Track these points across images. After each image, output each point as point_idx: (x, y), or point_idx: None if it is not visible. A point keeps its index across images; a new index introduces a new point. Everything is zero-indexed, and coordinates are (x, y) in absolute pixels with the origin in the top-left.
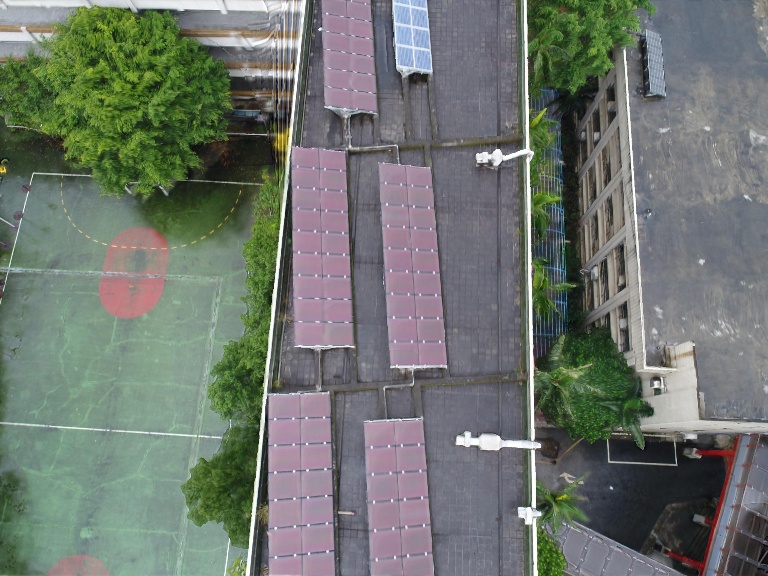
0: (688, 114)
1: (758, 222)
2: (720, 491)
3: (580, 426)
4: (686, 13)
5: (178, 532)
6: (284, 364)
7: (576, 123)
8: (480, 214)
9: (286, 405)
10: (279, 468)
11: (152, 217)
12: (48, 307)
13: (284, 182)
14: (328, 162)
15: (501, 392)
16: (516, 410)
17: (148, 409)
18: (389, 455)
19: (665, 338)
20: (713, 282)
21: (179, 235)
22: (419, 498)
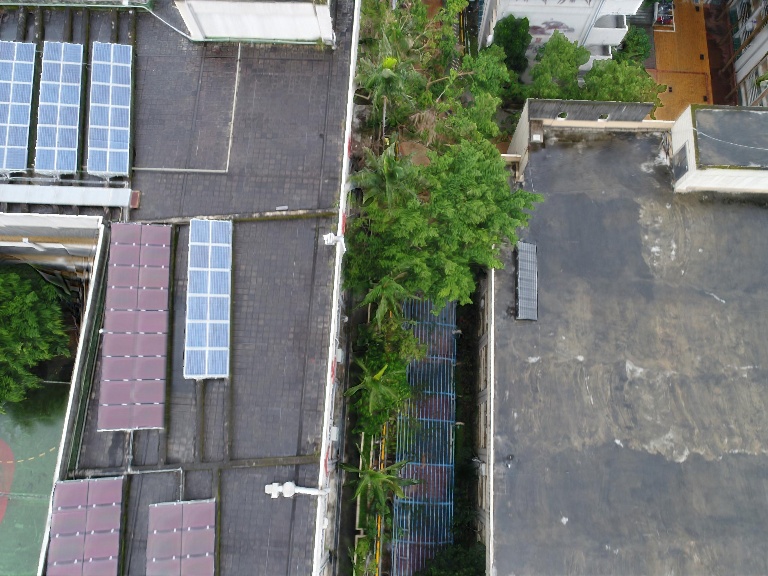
0: (561, 340)
1: (629, 473)
2: None
3: None
4: (566, 218)
5: None
6: None
7: (479, 284)
8: (268, 555)
9: None
10: None
11: None
12: None
13: None
14: (99, 496)
15: None
16: None
17: None
18: None
19: None
20: (575, 545)
21: (27, 446)
22: None
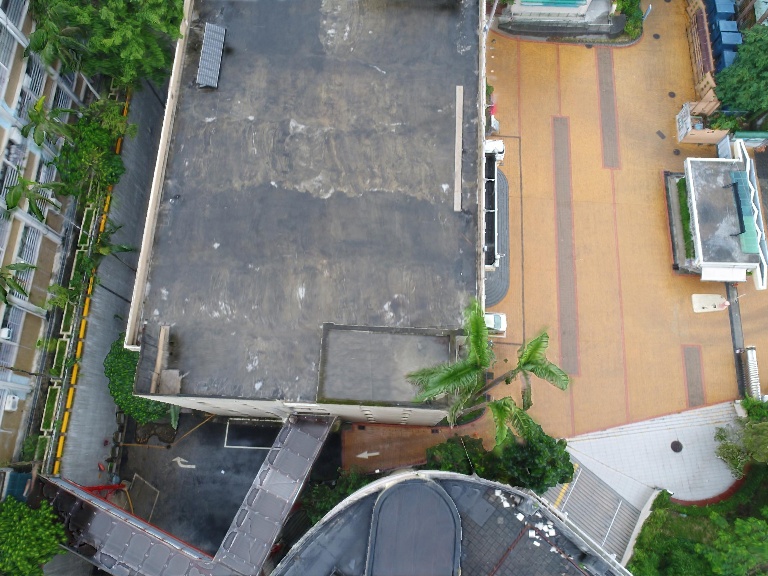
0: (236, 104)
1: (278, 207)
2: (332, 475)
3: (128, 407)
4: (257, 8)
5: None
6: None
7: None
8: None
9: None
10: None
11: None
12: None
13: None
14: None
15: None
16: None
17: None
18: None
19: (165, 319)
20: (222, 265)
21: None
22: None
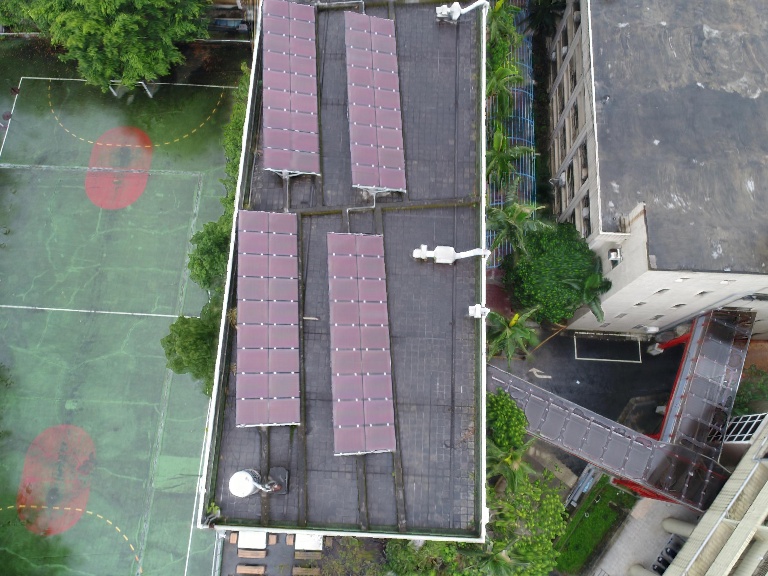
0: (646, 10)
1: (710, 107)
2: None
3: (544, 306)
4: None
5: (159, 403)
6: (255, 192)
7: (548, 47)
8: (440, 62)
9: (255, 220)
10: (248, 273)
11: (136, 117)
12: (35, 199)
13: (256, 29)
14: (298, 13)
15: (456, 215)
16: (470, 230)
17: (131, 292)
18: (350, 263)
19: (621, 210)
20: (667, 160)
21: (162, 134)
22: (378, 302)
